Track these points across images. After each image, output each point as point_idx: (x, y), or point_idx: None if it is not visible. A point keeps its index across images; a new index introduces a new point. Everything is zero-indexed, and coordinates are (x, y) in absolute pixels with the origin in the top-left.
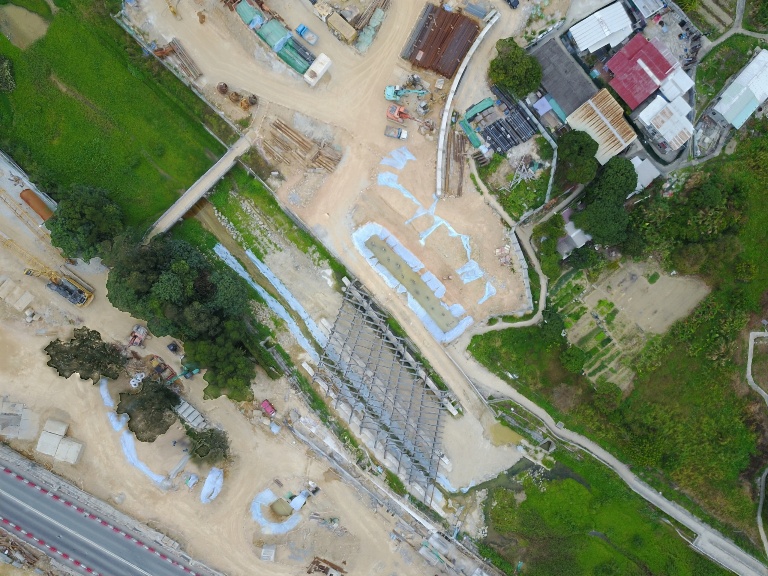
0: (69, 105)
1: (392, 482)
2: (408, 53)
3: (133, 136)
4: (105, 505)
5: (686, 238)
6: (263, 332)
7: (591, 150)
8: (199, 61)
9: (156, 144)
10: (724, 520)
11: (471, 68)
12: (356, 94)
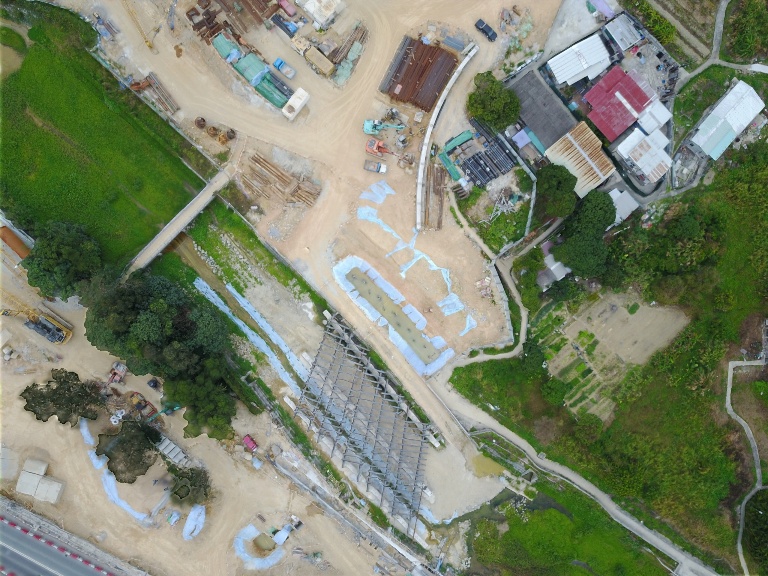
0: (45, 140)
1: (375, 515)
2: (387, 87)
3: (111, 171)
4: (86, 544)
5: (665, 269)
6: (244, 367)
7: (569, 185)
8: (176, 95)
9: (134, 179)
10: (705, 548)
11: (450, 101)
12: (335, 128)
